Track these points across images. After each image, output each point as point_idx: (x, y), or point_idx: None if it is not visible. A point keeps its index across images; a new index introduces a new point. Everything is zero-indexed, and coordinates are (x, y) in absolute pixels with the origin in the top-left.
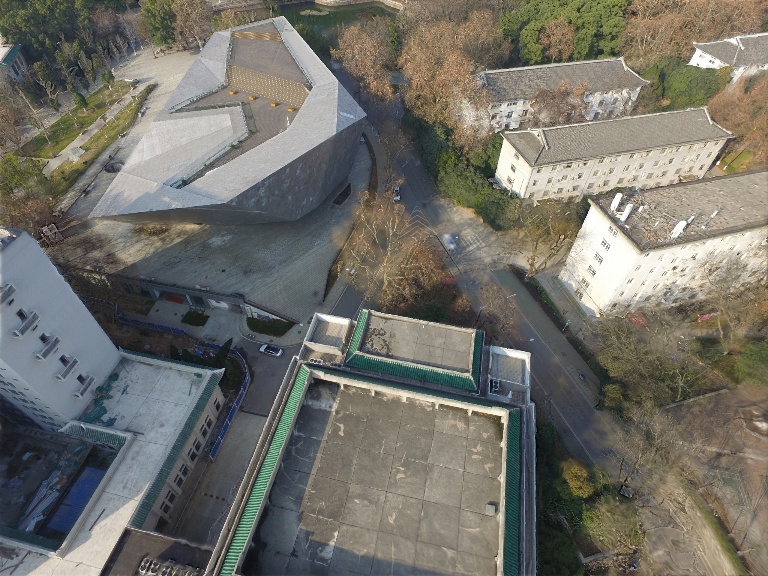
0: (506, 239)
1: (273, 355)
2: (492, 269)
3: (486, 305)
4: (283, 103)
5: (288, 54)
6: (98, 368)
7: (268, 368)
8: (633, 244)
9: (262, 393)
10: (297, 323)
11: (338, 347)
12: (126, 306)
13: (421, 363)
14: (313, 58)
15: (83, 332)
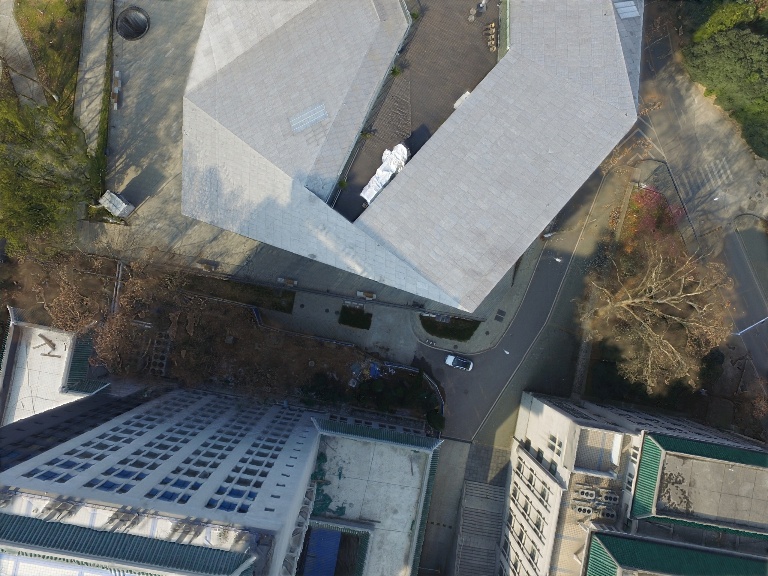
0: (766, 167)
1: (463, 369)
2: (739, 228)
3: None
4: None
5: None
6: (311, 467)
7: (459, 384)
8: None
9: (459, 416)
10: (483, 321)
11: (613, 477)
12: (259, 300)
13: (726, 521)
14: None
15: (306, 476)
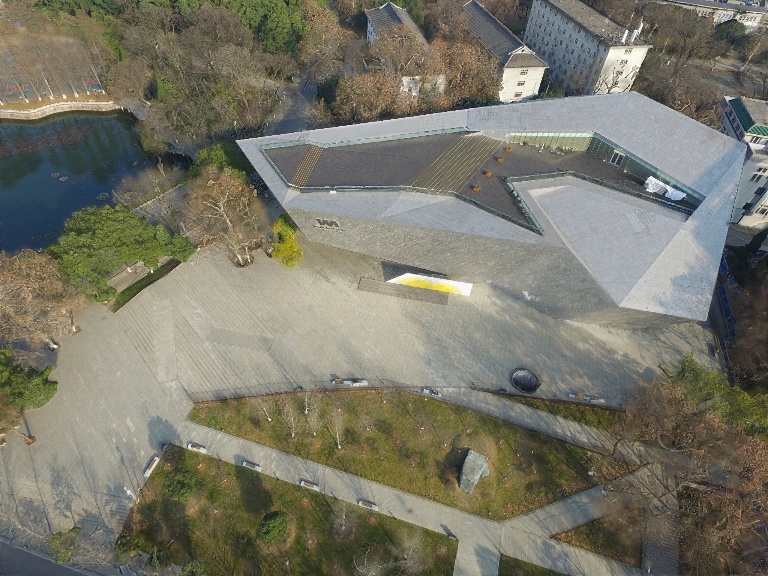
0: None
1: None
2: None
3: (702, 100)
4: (494, 155)
5: (372, 144)
6: None
7: None
8: (648, 45)
9: None
10: None
11: None
12: None
13: None
14: (402, 122)
15: None
